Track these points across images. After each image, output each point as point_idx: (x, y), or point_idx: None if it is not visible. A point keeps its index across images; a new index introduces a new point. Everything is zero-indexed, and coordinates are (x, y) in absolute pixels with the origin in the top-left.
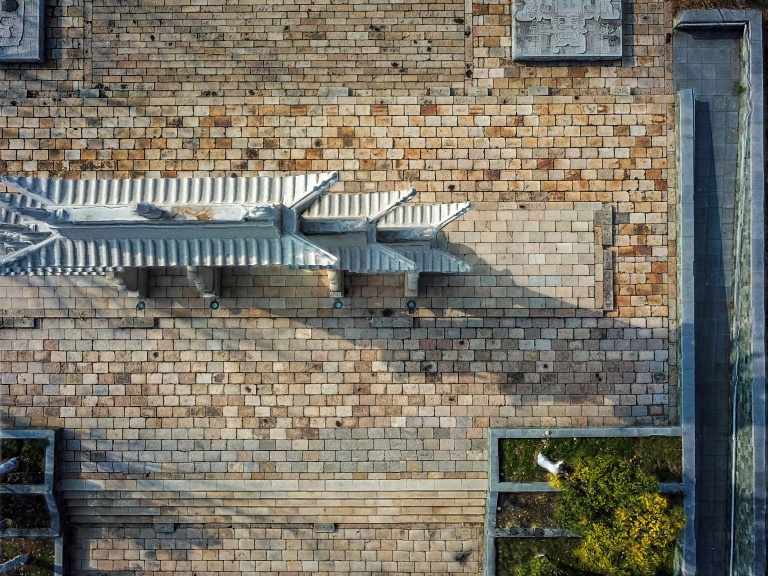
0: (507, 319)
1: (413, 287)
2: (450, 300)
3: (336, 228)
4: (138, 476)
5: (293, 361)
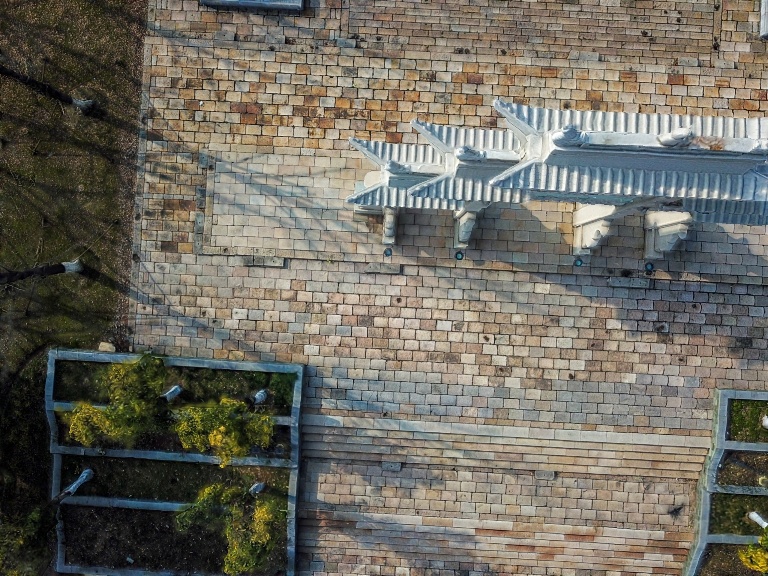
0: (739, 286)
1: (668, 248)
2: (687, 264)
3: (767, 171)
4: (376, 415)
5: (531, 314)
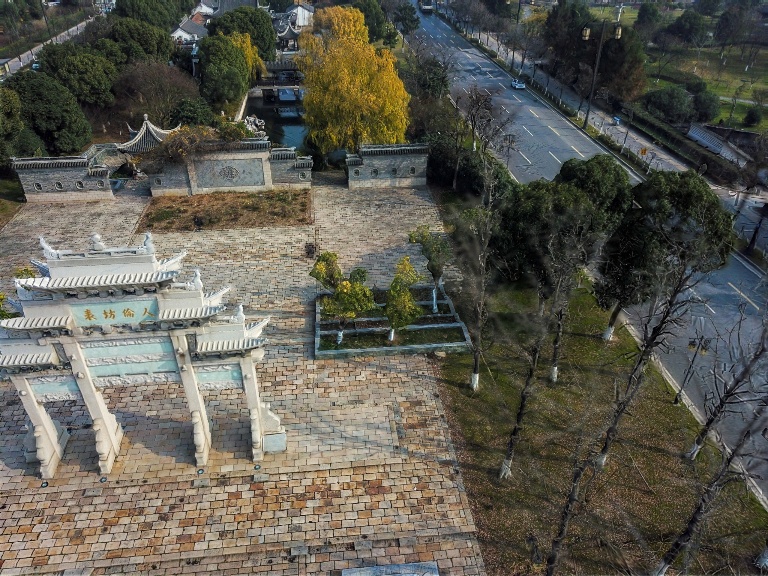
0: None
1: None
2: None
3: (35, 292)
4: (270, 345)
5: (163, 399)
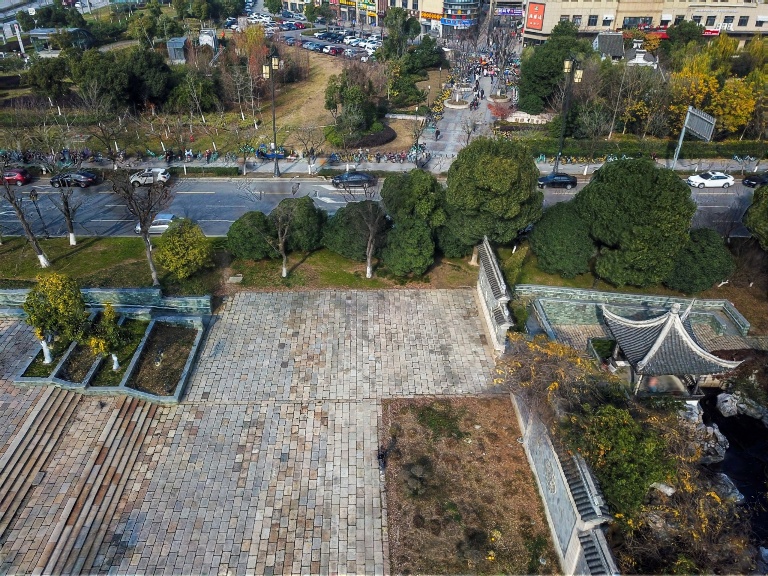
0: None
1: None
2: None
3: None
4: None
5: None
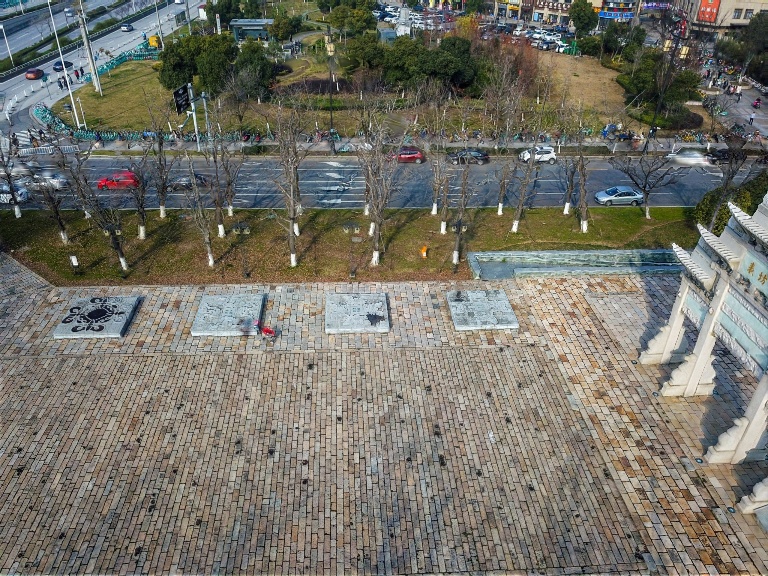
0: None
1: None
2: None
3: None
4: None
5: None
